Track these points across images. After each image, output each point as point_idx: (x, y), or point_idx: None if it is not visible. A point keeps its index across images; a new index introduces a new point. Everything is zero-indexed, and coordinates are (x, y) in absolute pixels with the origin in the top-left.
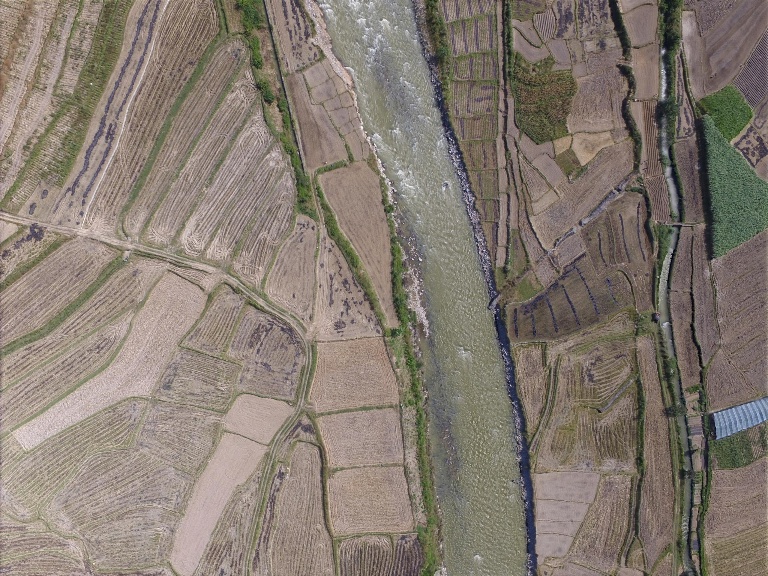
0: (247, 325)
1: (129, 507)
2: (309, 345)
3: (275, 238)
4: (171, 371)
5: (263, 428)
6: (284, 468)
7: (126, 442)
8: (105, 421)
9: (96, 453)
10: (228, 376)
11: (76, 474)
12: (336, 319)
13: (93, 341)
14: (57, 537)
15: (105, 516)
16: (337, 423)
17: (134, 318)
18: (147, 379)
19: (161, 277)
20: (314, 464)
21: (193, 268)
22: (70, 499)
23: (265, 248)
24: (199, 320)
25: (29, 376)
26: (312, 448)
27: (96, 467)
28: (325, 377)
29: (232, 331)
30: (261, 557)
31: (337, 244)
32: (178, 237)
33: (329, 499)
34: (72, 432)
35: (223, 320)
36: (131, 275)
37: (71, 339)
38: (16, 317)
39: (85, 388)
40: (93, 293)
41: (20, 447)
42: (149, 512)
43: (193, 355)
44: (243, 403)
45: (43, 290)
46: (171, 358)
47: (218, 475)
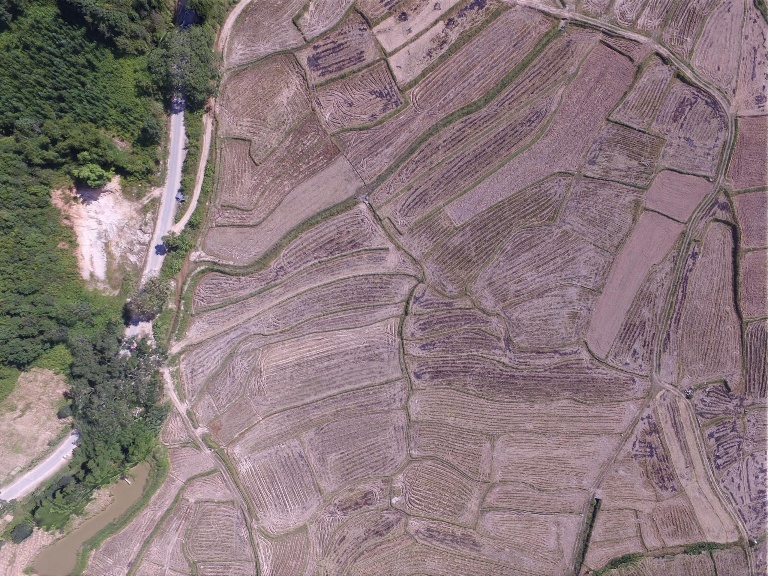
0: (672, 99)
1: (549, 285)
2: (732, 119)
3: (704, 7)
4: (597, 146)
5: (682, 205)
6: (697, 248)
7: (551, 218)
8: (531, 197)
9: (521, 230)
10: (652, 151)
11: (501, 251)
12: (757, 93)
13: (525, 114)
14: (480, 314)
15: (526, 294)
16: (751, 202)
17: (564, 91)
18: (574, 154)
19: (593, 48)
20: (726, 244)
21: (625, 38)
22: (494, 276)
23: (694, 18)
24: (628, 92)
25: (463, 150)
26: (725, 228)
27: (520, 244)
28: (743, 154)
29: (660, 103)
30: (671, 338)
31: (763, 14)
32: (611, 6)
33: (739, 280)
34: (500, 208)
35: (651, 92)
36: (565, 46)
37: (505, 112)
38: (455, 89)
39: (514, 163)
40: (529, 64)
41: (451, 222)
42: (568, 290)
43: (619, 129)
44: (663, 180)
45: (481, 61)
46: (597, 132)
47: (635, 254)
